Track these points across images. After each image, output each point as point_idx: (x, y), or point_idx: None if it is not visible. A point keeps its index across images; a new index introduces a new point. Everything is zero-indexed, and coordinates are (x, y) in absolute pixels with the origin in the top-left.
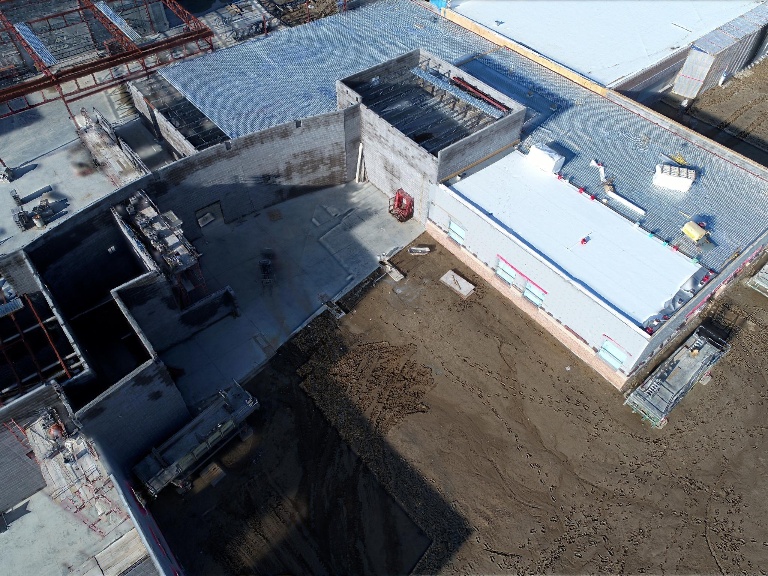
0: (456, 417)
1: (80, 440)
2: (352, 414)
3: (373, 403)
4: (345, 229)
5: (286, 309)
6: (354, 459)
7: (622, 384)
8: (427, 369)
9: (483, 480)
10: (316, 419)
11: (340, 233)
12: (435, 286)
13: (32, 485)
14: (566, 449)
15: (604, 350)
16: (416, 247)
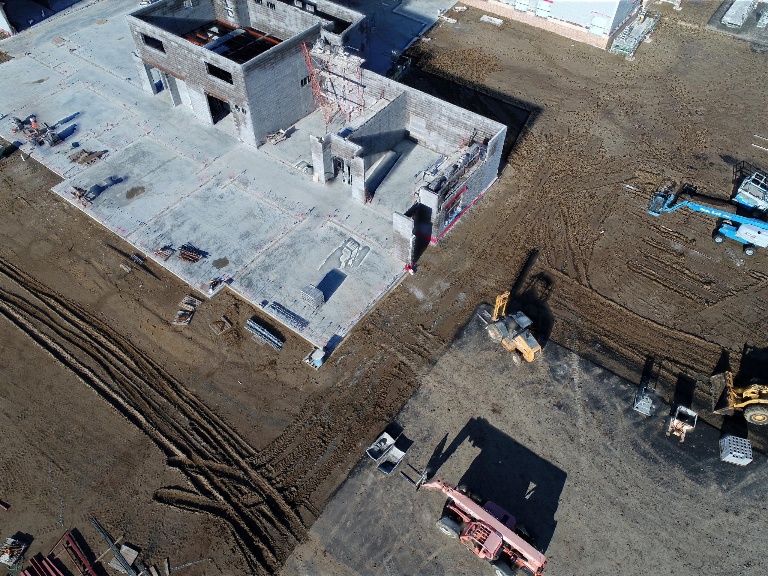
0: (519, 71)
1: (343, 52)
2: (460, 76)
3: (469, 71)
4: (407, 5)
5: (393, 41)
6: (472, 90)
7: (606, 44)
8: (493, 55)
9: (547, 90)
10: (440, 80)
11: (405, 7)
12: (478, 23)
13: (296, 114)
14: (585, 74)
15: (592, 26)
16: (458, 7)
